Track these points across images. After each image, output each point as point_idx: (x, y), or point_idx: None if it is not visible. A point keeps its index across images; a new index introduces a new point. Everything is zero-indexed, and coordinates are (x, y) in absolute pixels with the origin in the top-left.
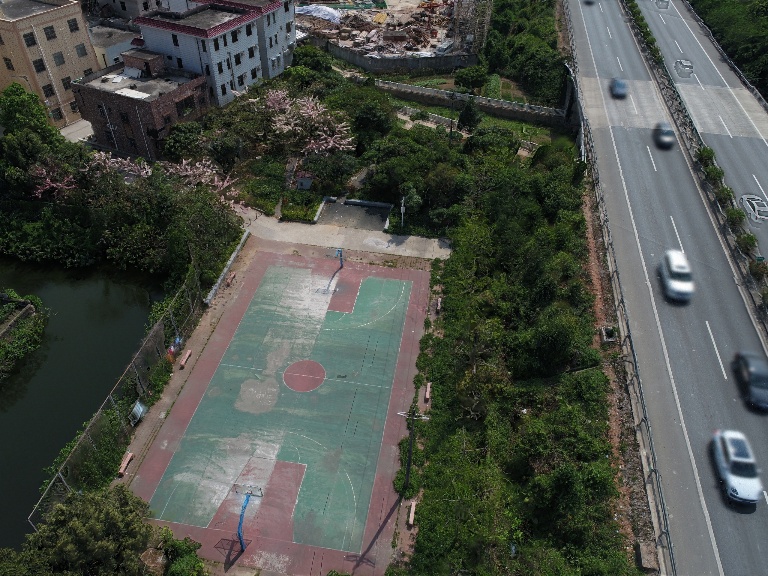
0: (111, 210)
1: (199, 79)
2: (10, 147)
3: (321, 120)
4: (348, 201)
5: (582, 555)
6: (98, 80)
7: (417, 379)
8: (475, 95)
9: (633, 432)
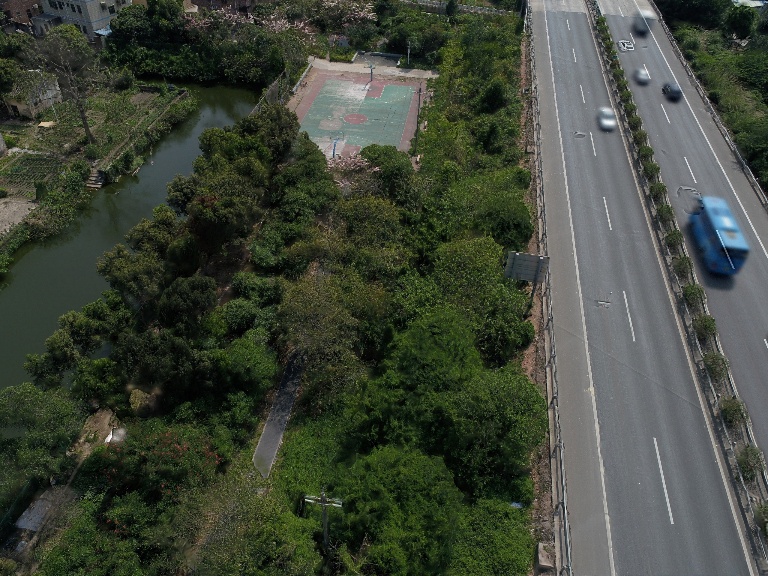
0: (227, 46)
1: None
2: (161, 7)
3: (354, 1)
4: (372, 53)
5: None
6: None
7: (419, 120)
8: None
9: (531, 119)
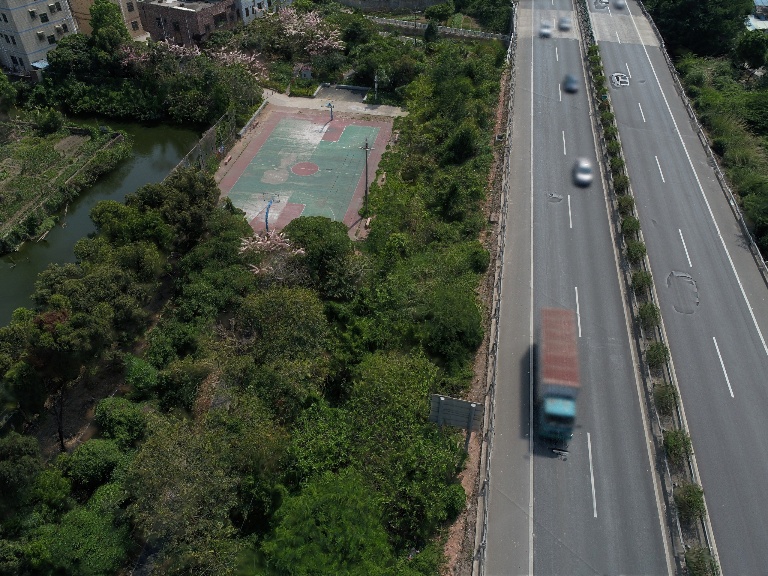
0: (172, 81)
1: (230, 1)
2: (101, 38)
3: (319, 28)
4: (338, 86)
5: (461, 224)
6: (155, 2)
7: (378, 171)
8: (441, 27)
9: (501, 175)
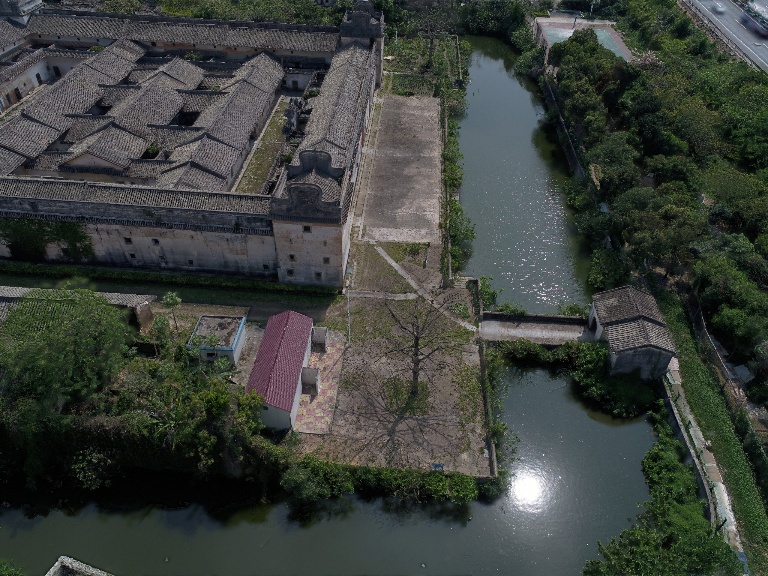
0: (469, 6)
1: None
2: None
3: None
4: (558, 10)
5: None
6: None
7: None
8: None
9: (719, 38)
